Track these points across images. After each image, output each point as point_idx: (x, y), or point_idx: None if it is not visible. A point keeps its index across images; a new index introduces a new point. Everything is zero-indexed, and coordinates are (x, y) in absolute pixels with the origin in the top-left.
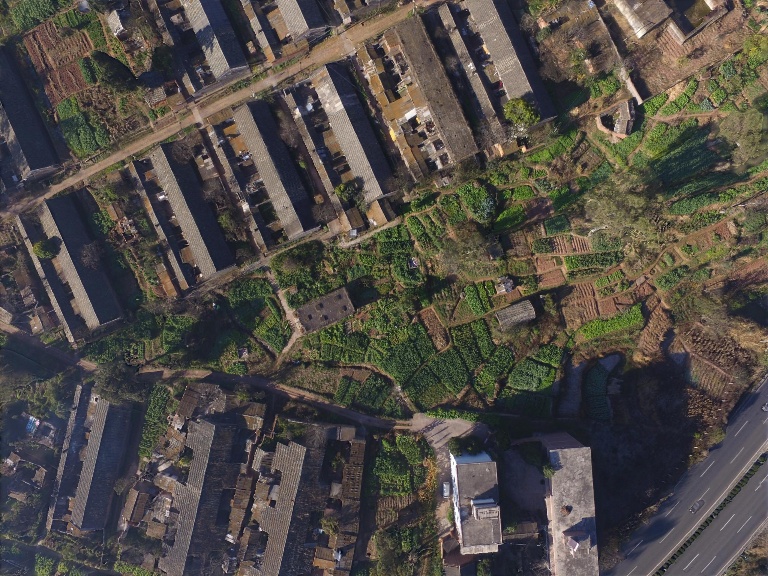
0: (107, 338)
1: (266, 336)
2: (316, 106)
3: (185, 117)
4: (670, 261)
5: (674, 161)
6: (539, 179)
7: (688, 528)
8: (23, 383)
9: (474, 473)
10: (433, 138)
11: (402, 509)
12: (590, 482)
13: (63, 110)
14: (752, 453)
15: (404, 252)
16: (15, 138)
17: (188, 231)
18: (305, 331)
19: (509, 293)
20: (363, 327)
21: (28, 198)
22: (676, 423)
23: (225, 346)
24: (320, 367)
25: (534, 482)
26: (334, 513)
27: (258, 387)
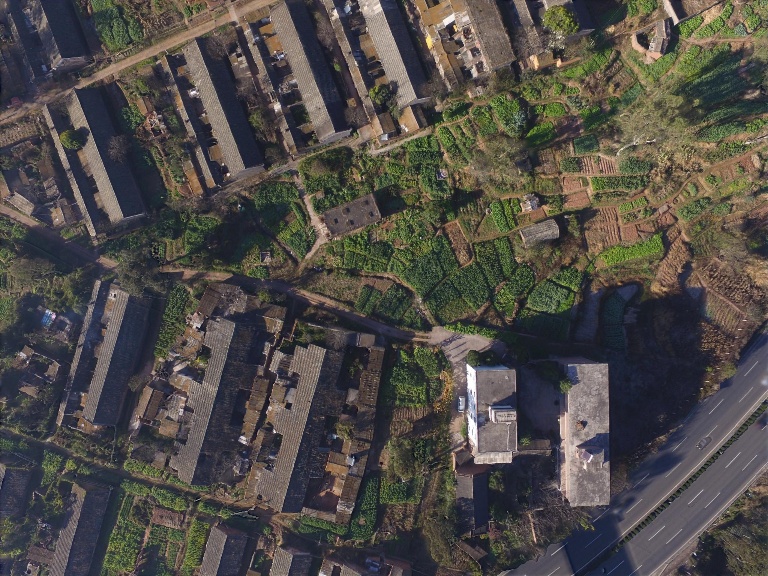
0: (128, 236)
1: (290, 241)
2: (354, 9)
3: (221, 15)
4: (694, 191)
5: (705, 85)
6: (571, 96)
7: (694, 464)
8: (43, 271)
9: (493, 380)
10: (470, 46)
11: (417, 420)
12: (606, 398)
13: (97, 2)
14: (760, 393)
15: (433, 163)
16: (47, 25)
17: (218, 128)
18: (330, 235)
19: (534, 212)
20: (387, 237)
21: (56, 90)
22: (689, 356)
23: (248, 249)
24: (342, 274)
25: (548, 403)
26: (349, 419)
27: (279, 292)
